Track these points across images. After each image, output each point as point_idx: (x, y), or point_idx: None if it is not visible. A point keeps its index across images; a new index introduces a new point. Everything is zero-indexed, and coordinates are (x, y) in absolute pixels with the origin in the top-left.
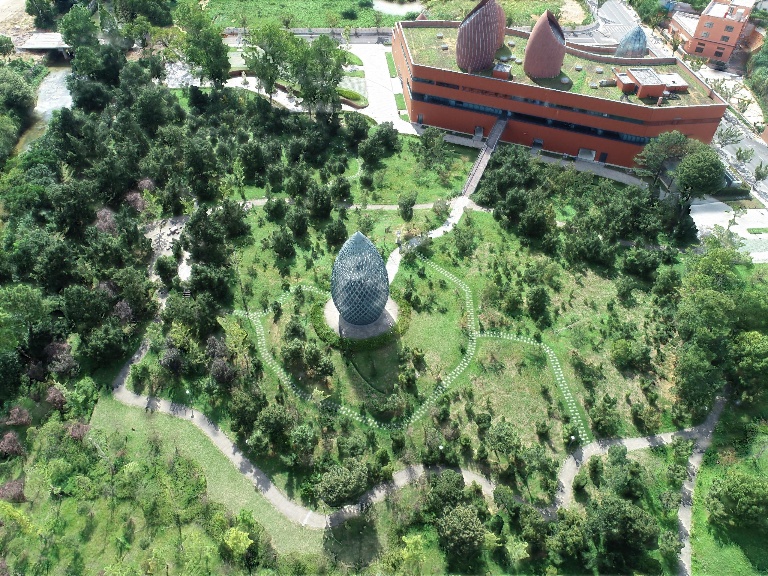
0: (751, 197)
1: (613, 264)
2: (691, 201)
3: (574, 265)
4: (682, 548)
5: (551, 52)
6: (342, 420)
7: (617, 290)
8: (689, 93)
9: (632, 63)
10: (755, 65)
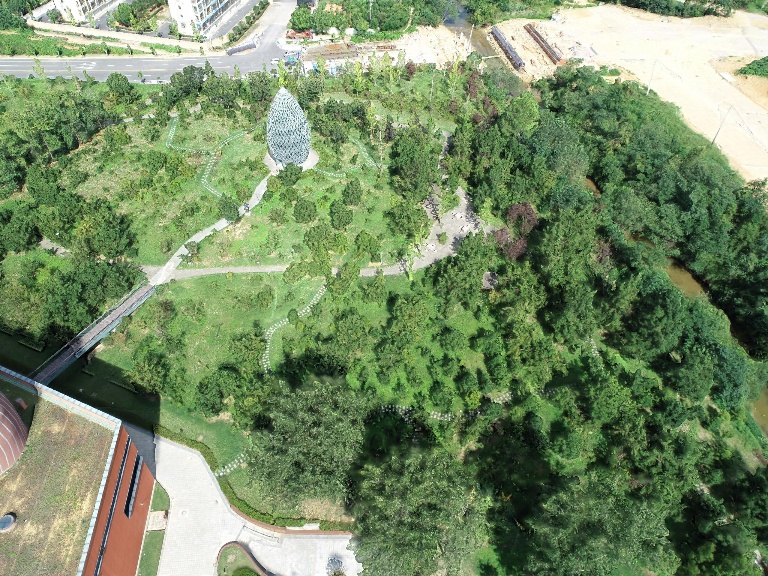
0: None
1: None
2: None
3: None
4: None
5: None
6: (311, 114)
7: None
8: None
9: None
10: None
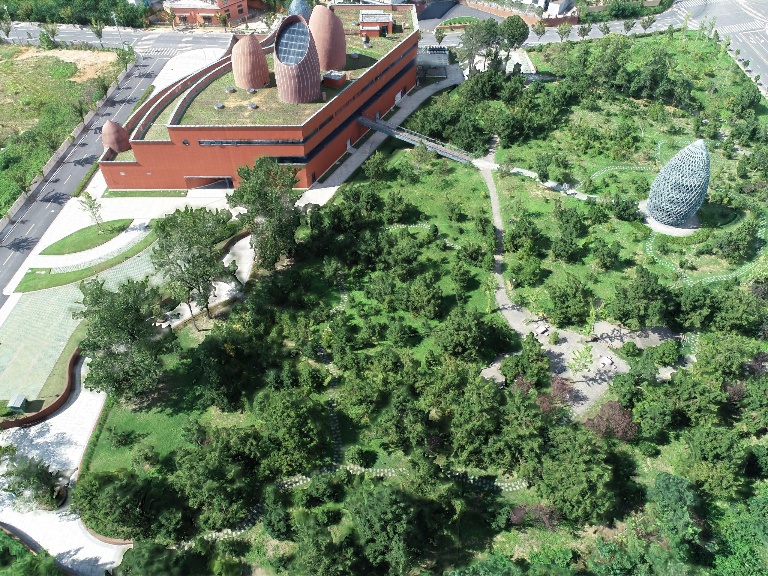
0: None
1: None
2: None
3: None
4: (767, 133)
5: None
6: None
7: None
8: None
9: None
10: (280, 1)
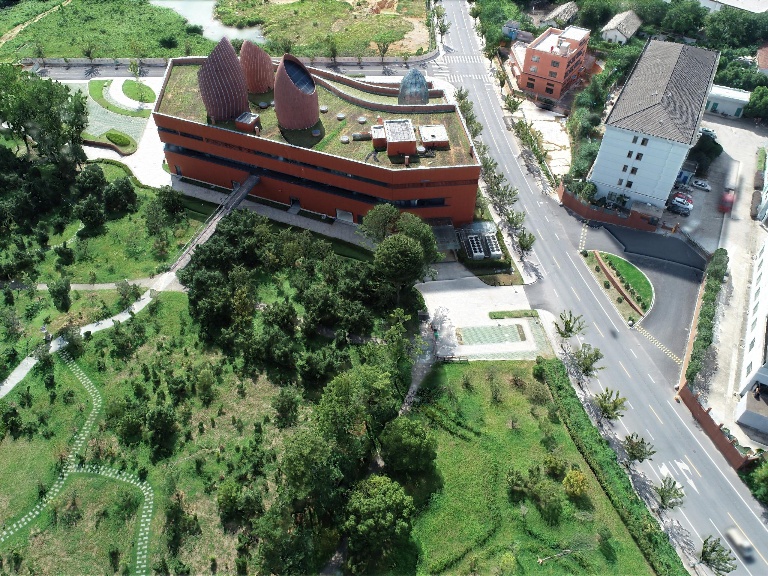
0: (512, 270)
1: (294, 366)
2: (410, 284)
3: (245, 368)
4: None
5: (294, 102)
6: None
7: (271, 406)
8: (449, 149)
9: (405, 110)
10: (578, 105)
